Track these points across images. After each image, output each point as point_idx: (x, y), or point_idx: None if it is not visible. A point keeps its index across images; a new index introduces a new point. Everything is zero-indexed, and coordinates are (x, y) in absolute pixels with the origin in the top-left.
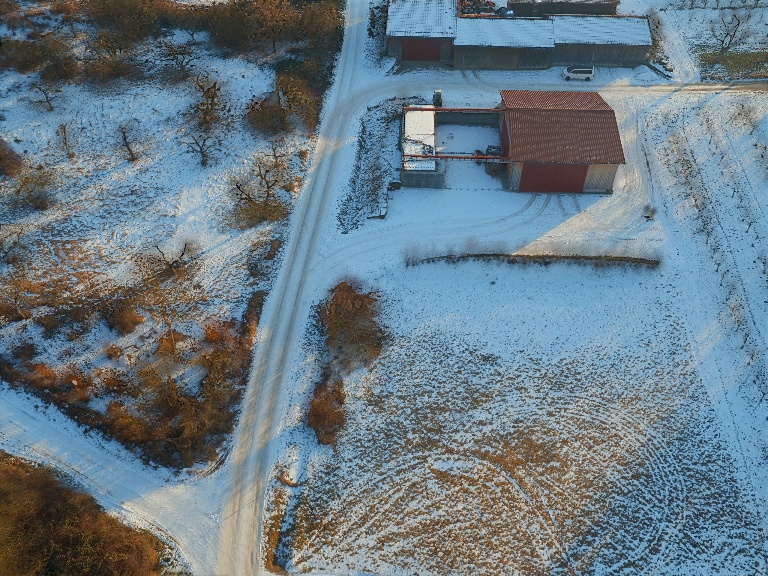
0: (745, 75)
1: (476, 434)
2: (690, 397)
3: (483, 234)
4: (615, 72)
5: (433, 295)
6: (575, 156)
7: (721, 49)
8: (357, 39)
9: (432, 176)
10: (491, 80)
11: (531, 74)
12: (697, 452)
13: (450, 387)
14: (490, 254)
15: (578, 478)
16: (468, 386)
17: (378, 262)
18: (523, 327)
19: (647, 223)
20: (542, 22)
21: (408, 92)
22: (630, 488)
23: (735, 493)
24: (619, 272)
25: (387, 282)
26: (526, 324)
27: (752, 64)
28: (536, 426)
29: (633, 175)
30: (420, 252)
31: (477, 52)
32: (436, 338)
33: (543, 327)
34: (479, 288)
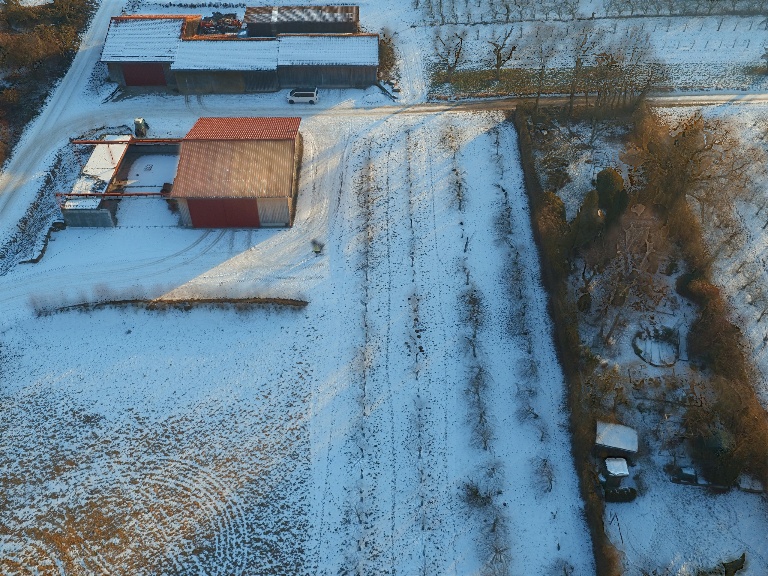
0: (471, 94)
1: (41, 509)
2: (290, 455)
3: (134, 277)
4: (345, 94)
5: (59, 348)
6: (240, 190)
7: (448, 68)
8: (87, 64)
9: (96, 215)
10: (213, 105)
11: (258, 98)
12: (274, 519)
13: (36, 455)
14: (131, 300)
15: (133, 556)
16: (56, 453)
17: (11, 313)
18: (142, 381)
19: (315, 259)
20: (268, 43)
21: (119, 120)
22: (185, 565)
23: (297, 566)
24: (263, 315)
25: (14, 335)
26: (146, 378)
27: (482, 82)
28: (112, 497)
29: (321, 206)
30: (59, 300)
31: (199, 76)
32: (43, 398)
33: (164, 380)
34: (112, 338)
